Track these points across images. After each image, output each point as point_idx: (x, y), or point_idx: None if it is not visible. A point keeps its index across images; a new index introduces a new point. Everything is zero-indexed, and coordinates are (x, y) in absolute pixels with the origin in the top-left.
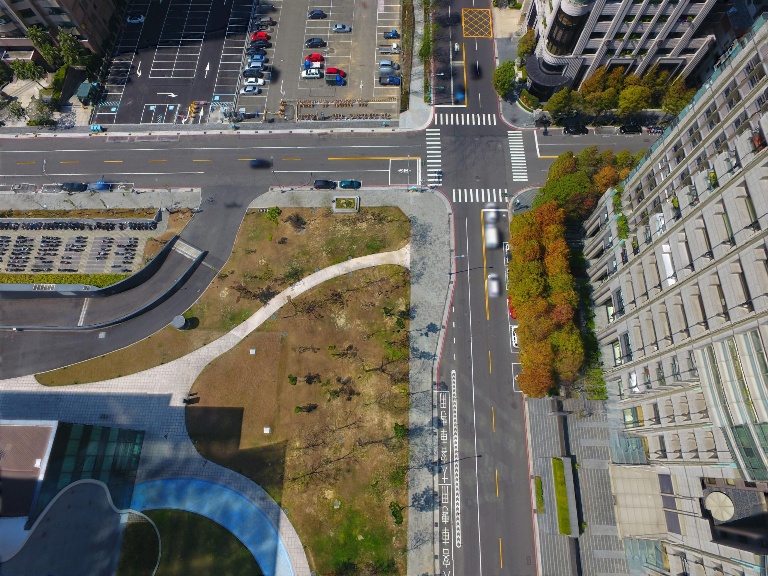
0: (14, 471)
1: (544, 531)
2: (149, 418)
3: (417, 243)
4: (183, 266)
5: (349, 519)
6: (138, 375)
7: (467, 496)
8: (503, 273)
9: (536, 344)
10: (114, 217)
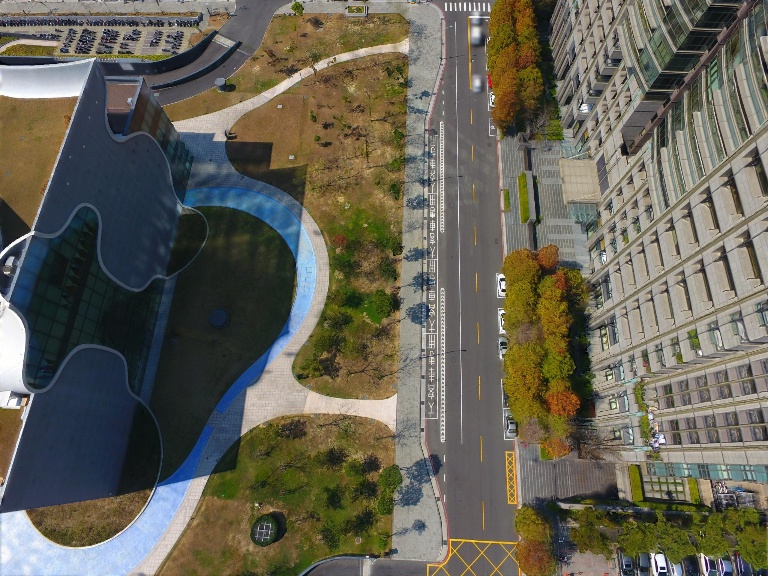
0: (111, 109)
1: (509, 223)
2: (197, 148)
3: (415, 38)
4: (221, 52)
5: (357, 214)
6: (187, 121)
7: (450, 201)
8: (484, 59)
9: (506, 73)
10: (164, 16)
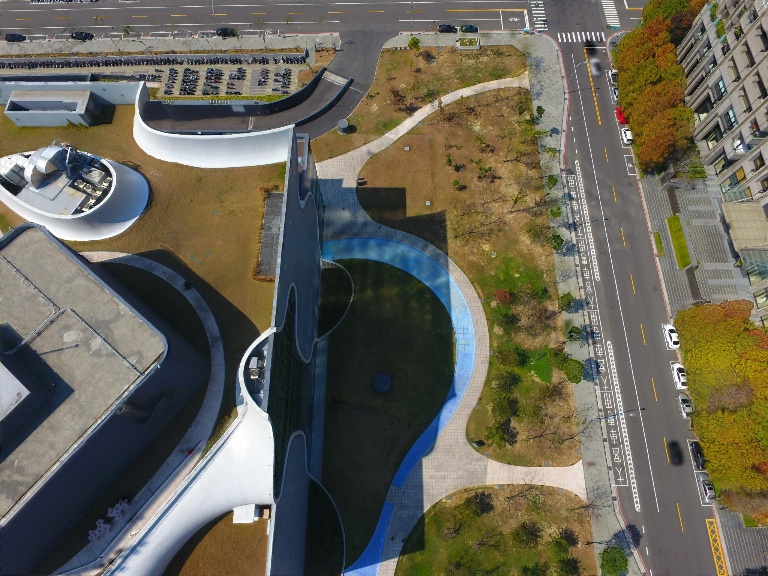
0: None
1: (666, 268)
2: (327, 196)
3: (533, 71)
4: (333, 91)
5: (505, 263)
6: None
7: (600, 246)
8: (608, 92)
9: (660, 113)
10: (268, 53)
